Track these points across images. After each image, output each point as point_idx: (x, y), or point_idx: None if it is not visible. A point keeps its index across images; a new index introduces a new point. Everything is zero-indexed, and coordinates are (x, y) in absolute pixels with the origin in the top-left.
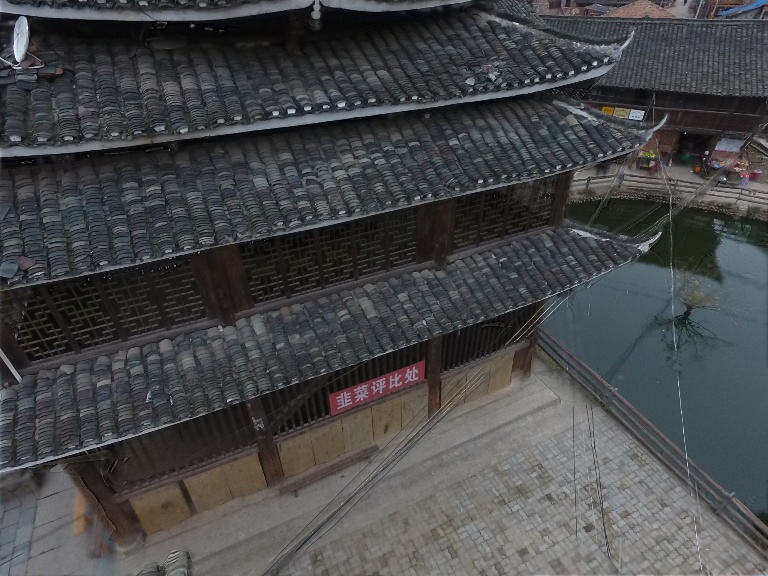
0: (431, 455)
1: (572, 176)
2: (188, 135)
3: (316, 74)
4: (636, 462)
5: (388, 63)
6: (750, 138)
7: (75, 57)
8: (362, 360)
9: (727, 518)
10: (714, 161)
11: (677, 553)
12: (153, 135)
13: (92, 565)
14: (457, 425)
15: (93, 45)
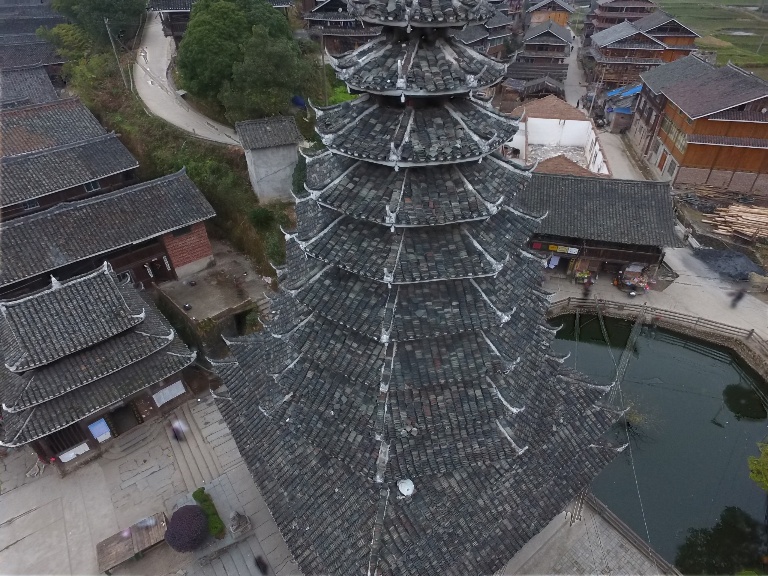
0: (518, 568)
1: None
2: None
3: None
4: (623, 550)
5: None
6: (647, 266)
7: None
8: None
9: None
10: (626, 280)
11: None
12: None
13: None
14: (526, 544)
15: None
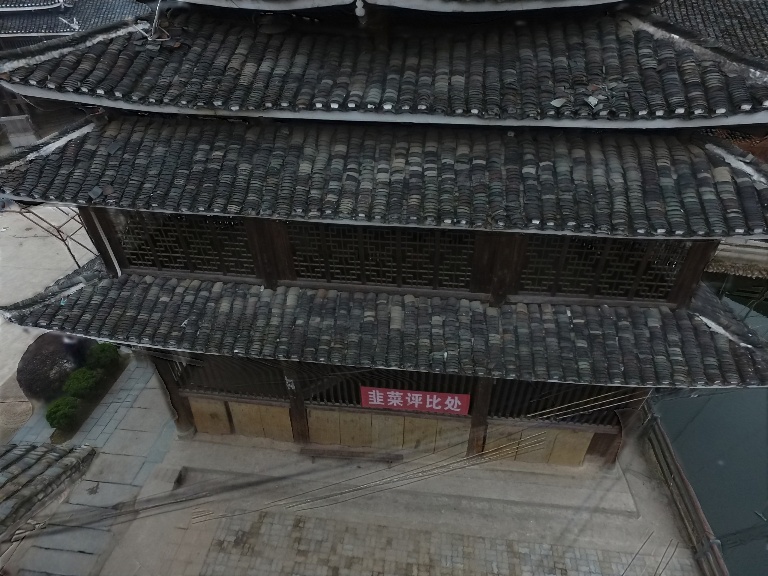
0: (450, 493)
1: (715, 248)
2: (244, 113)
3: (387, 71)
4: None
5: (471, 69)
6: None
7: (199, 34)
8: (364, 365)
9: None
10: None
11: None
12: (212, 108)
13: (158, 433)
14: (495, 478)
15: (219, 25)
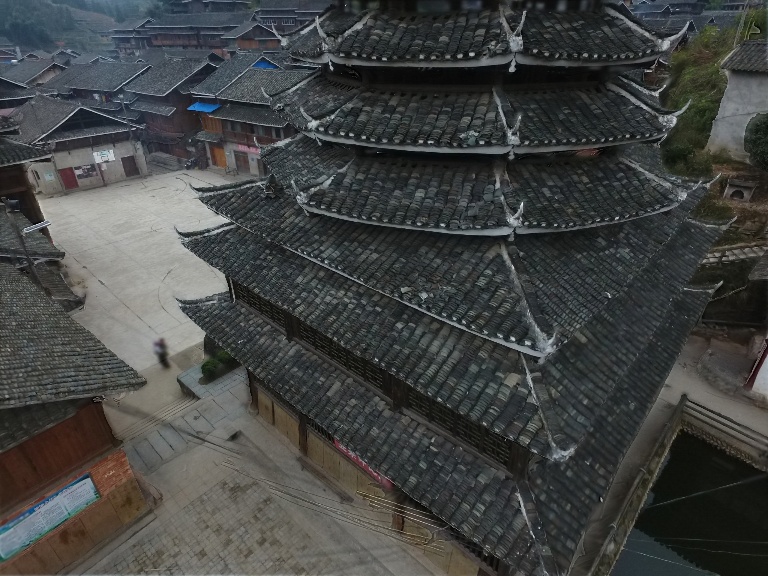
0: (365, 546)
1: None
2: None
3: None
4: None
5: None
6: None
7: None
8: None
9: None
10: None
11: None
12: None
13: None
14: (402, 558)
15: None
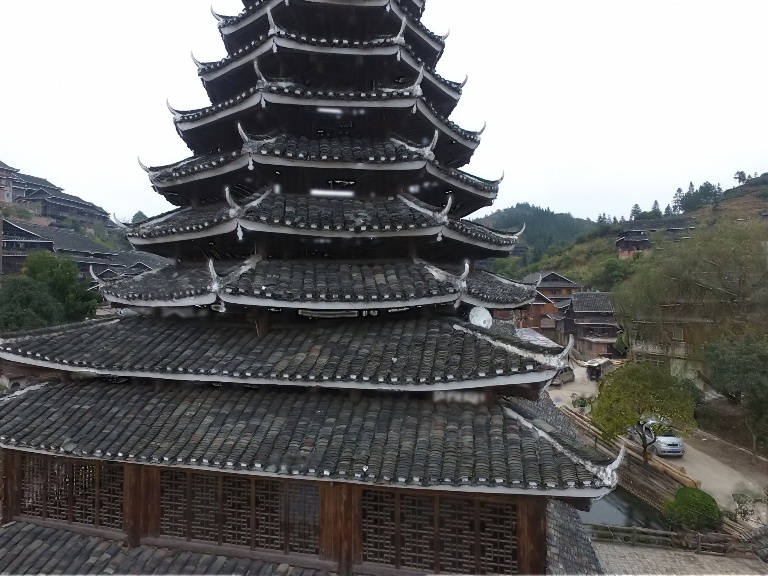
0: None
1: None
2: None
3: None
4: None
5: None
6: None
7: None
8: None
9: (640, 543)
10: None
11: (655, 570)
12: None
13: None
14: None
15: None
